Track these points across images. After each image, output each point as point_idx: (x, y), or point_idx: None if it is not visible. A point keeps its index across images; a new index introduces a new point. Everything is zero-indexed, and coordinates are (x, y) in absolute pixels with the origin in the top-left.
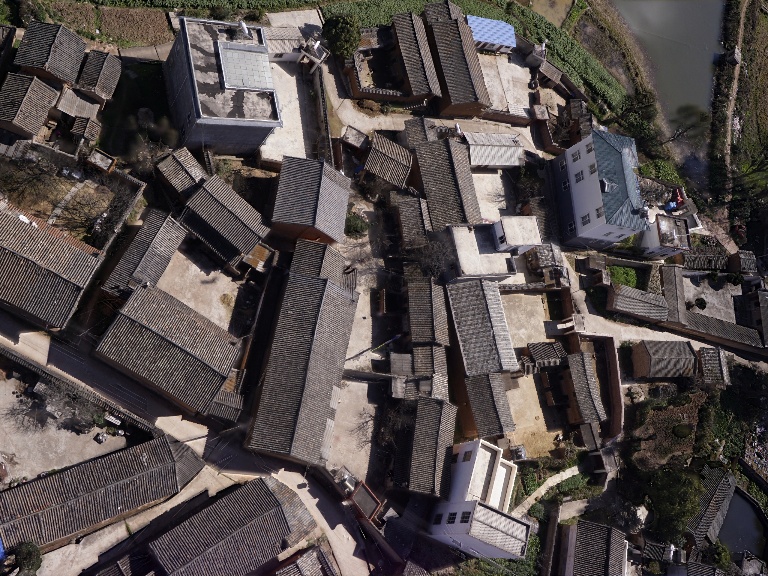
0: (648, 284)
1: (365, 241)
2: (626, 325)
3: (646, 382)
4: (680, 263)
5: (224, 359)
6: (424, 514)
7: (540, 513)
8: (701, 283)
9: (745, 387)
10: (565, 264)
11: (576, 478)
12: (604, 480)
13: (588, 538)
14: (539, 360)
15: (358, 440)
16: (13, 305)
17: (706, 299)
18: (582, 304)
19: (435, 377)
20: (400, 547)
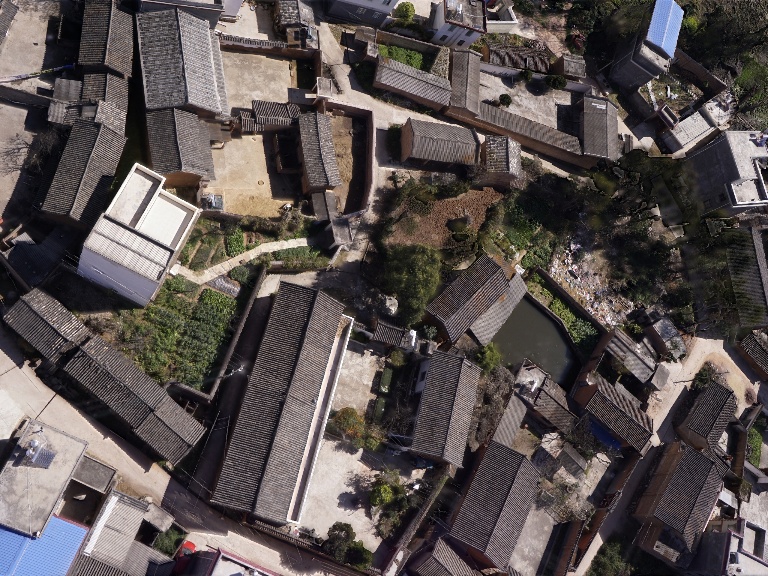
0: (432, 67)
1: None
2: (401, 108)
3: (418, 169)
4: (487, 58)
5: None
6: (70, 246)
7: (243, 276)
8: (516, 85)
9: (557, 196)
10: (327, 35)
11: (300, 249)
12: (334, 253)
13: (289, 300)
14: (261, 115)
15: (3, 165)
16: None
17: (520, 102)
18: (344, 78)
19: (105, 105)
20: (28, 273)
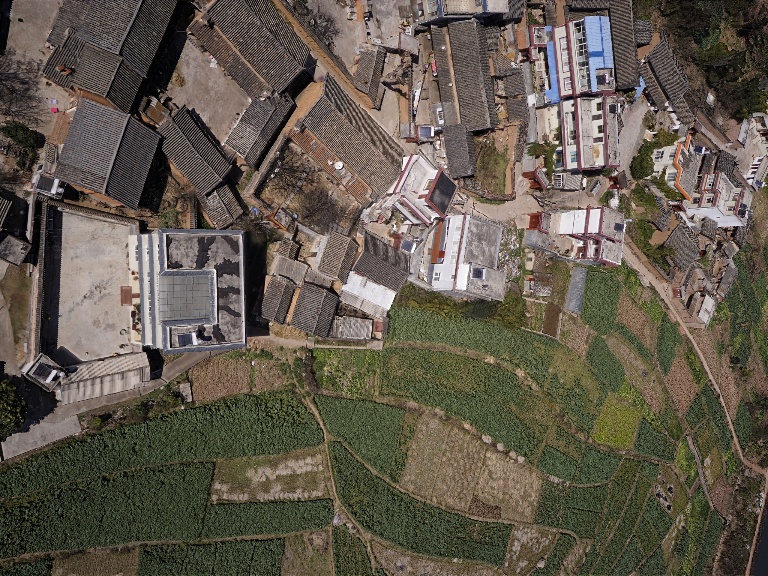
0: None
1: (1, 117)
2: None
3: None
4: None
5: (227, 7)
6: None
7: None
8: None
9: None
10: None
11: None
12: None
13: None
14: None
15: None
16: (351, 99)
17: None
18: None
19: None
20: None
